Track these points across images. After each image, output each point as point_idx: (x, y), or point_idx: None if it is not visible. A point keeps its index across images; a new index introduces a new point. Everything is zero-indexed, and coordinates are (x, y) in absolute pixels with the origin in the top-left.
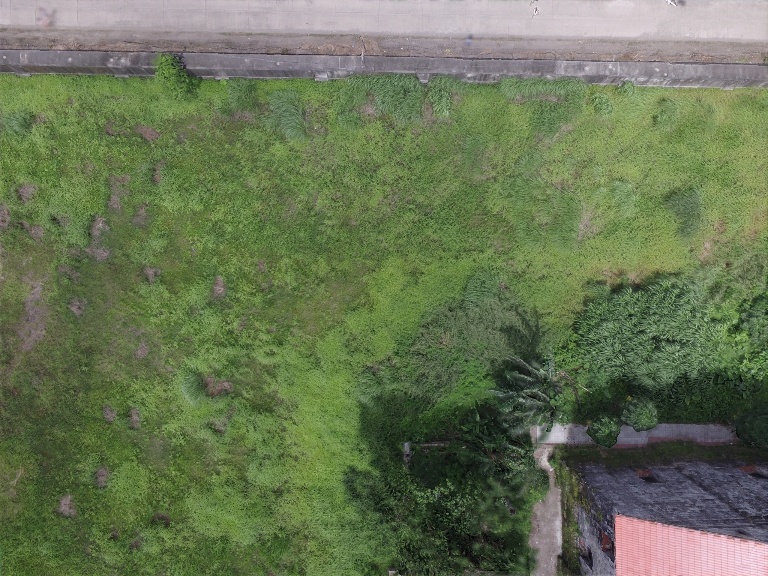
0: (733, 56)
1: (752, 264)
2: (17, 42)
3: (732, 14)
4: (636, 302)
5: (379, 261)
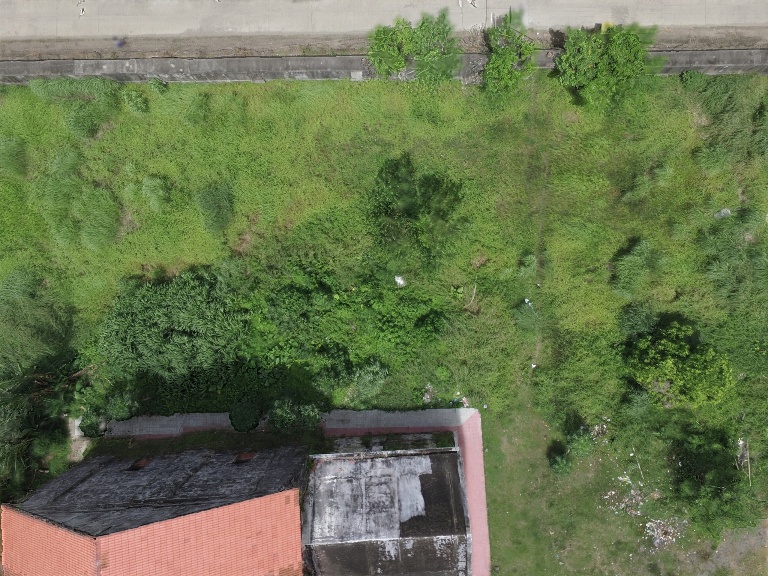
0: (275, 49)
1: (281, 253)
2: None
3: (273, 7)
4: (153, 295)
5: None
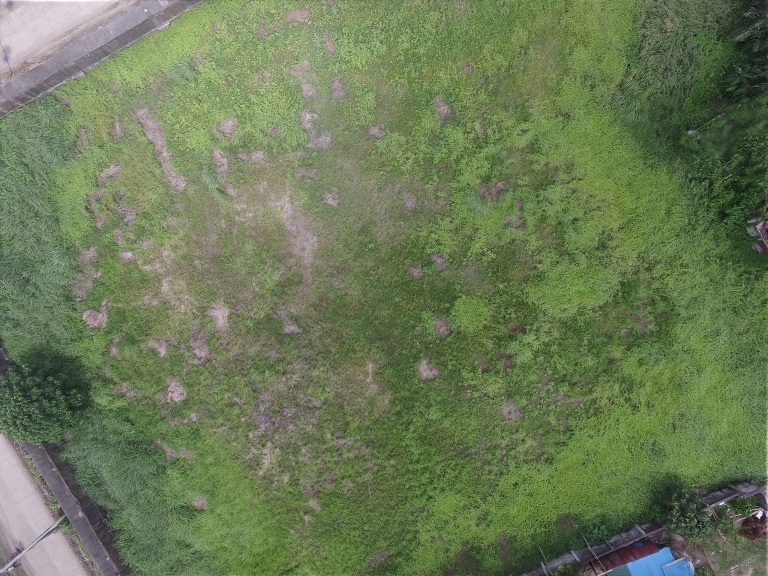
0: None
1: None
2: (135, 7)
3: None
4: None
5: (566, 0)
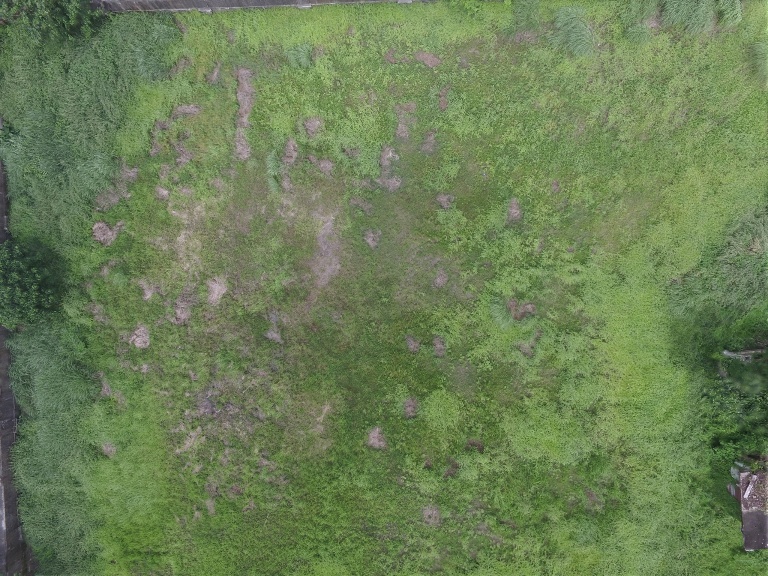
0: None
1: None
2: None
3: None
4: None
5: (676, 174)
